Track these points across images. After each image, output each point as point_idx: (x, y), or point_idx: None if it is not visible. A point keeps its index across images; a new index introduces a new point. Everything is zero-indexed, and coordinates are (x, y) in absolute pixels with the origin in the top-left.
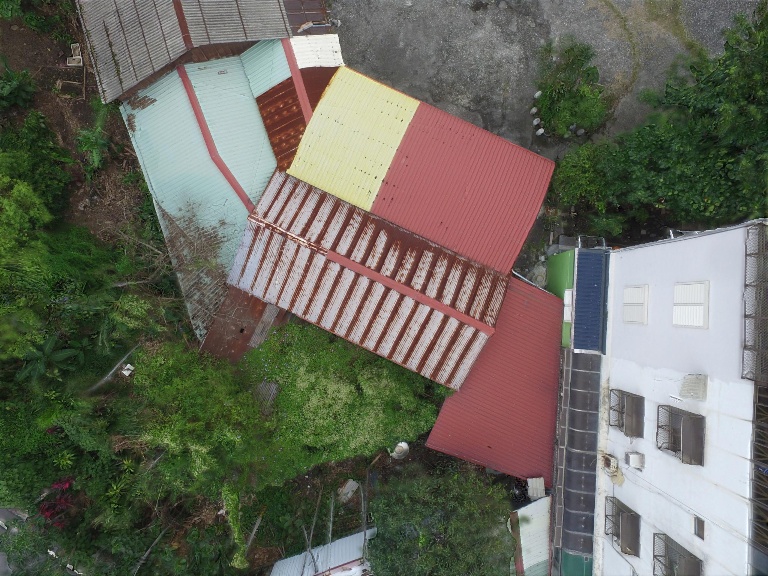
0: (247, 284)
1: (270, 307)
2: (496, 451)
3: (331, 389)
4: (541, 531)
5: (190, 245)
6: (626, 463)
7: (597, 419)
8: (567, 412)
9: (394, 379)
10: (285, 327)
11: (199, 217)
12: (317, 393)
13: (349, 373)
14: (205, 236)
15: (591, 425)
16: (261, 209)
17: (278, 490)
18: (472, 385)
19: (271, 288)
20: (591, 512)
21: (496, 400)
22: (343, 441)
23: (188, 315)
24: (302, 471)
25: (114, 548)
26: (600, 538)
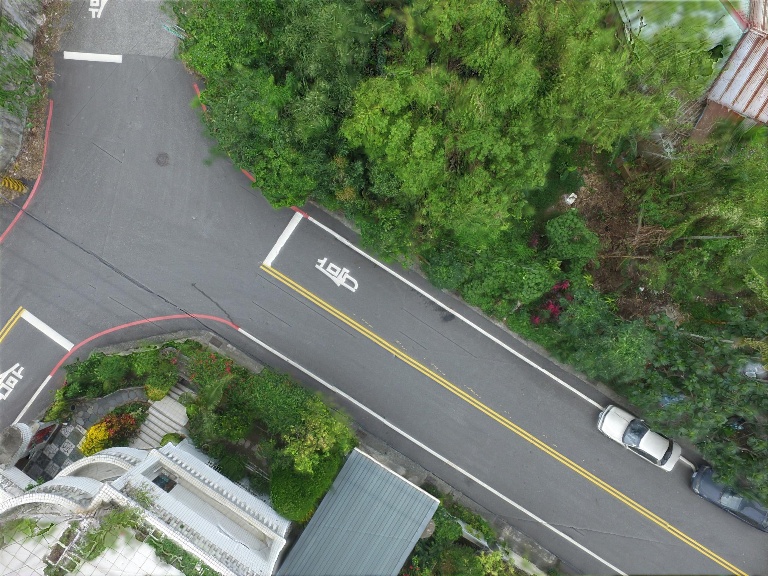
0: (729, 99)
1: (745, 122)
2: None
3: None
4: None
5: (661, 69)
6: None
7: None
8: None
9: None
10: (750, 144)
11: (677, 40)
12: None
13: None
14: (680, 58)
15: None
16: (758, 23)
17: (715, 308)
18: None
19: (754, 101)
20: None
21: None
22: None
23: (658, 135)
24: None
25: (661, 321)
26: None
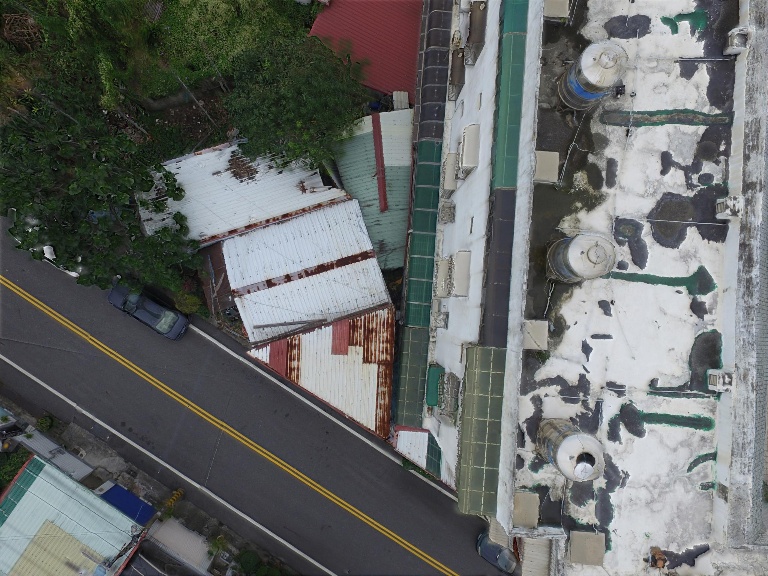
0: None
1: None
2: (364, 67)
3: (211, 4)
4: (404, 138)
5: None
6: (459, 9)
7: (451, 18)
8: (427, 20)
9: (274, 9)
10: None
11: None
12: (197, 7)
13: (232, 3)
14: None
15: (445, 23)
16: None
17: None
18: (342, 4)
19: None
20: (443, 102)
21: (365, 20)
22: (222, 56)
23: None
24: (184, 83)
25: None
26: (449, 121)
